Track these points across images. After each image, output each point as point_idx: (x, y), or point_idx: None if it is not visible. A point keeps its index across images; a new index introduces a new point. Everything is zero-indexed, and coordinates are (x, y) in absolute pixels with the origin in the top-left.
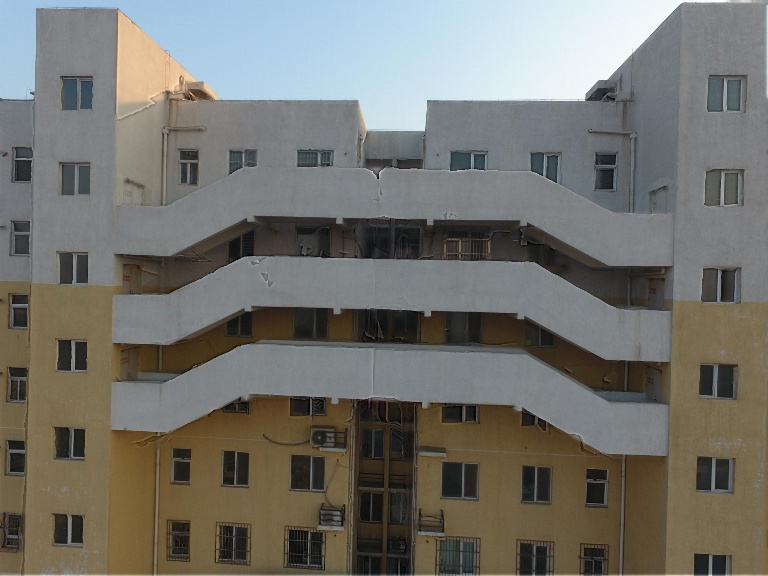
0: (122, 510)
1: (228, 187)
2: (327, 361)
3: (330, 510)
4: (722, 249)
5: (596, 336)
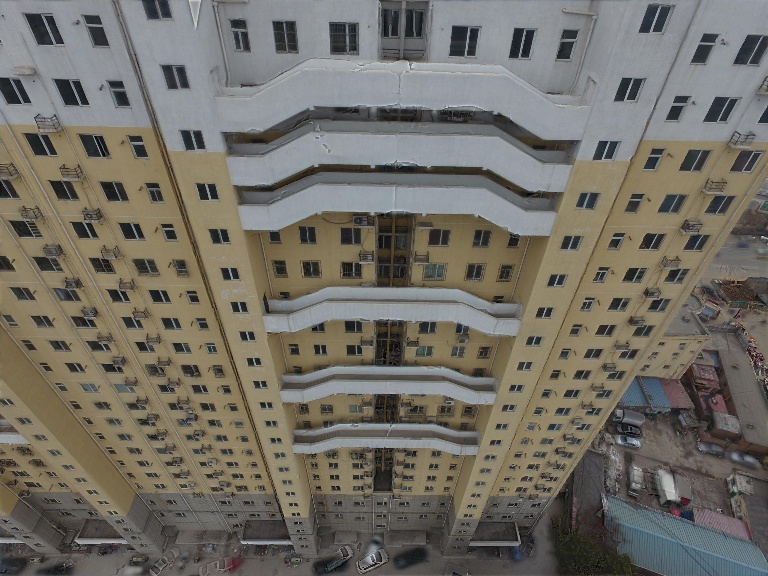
0: (254, 263)
1: (293, 85)
2: (367, 194)
3: (366, 255)
4: (614, 130)
5: (526, 179)
